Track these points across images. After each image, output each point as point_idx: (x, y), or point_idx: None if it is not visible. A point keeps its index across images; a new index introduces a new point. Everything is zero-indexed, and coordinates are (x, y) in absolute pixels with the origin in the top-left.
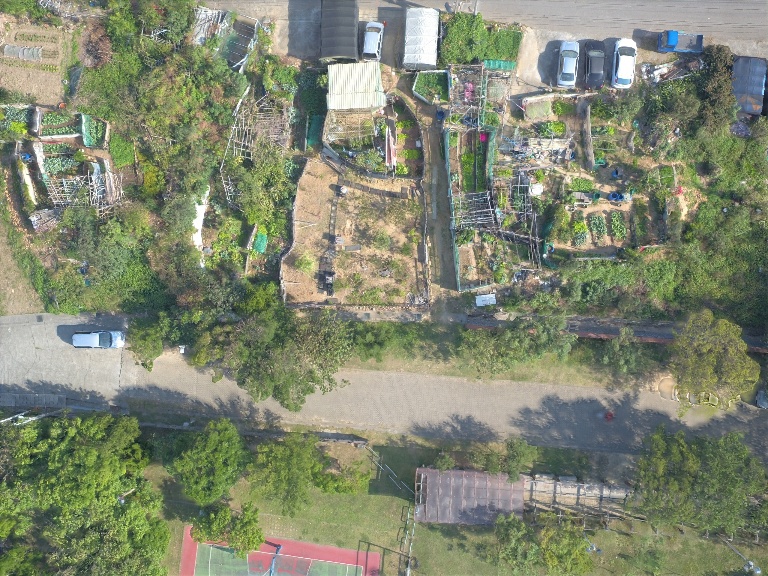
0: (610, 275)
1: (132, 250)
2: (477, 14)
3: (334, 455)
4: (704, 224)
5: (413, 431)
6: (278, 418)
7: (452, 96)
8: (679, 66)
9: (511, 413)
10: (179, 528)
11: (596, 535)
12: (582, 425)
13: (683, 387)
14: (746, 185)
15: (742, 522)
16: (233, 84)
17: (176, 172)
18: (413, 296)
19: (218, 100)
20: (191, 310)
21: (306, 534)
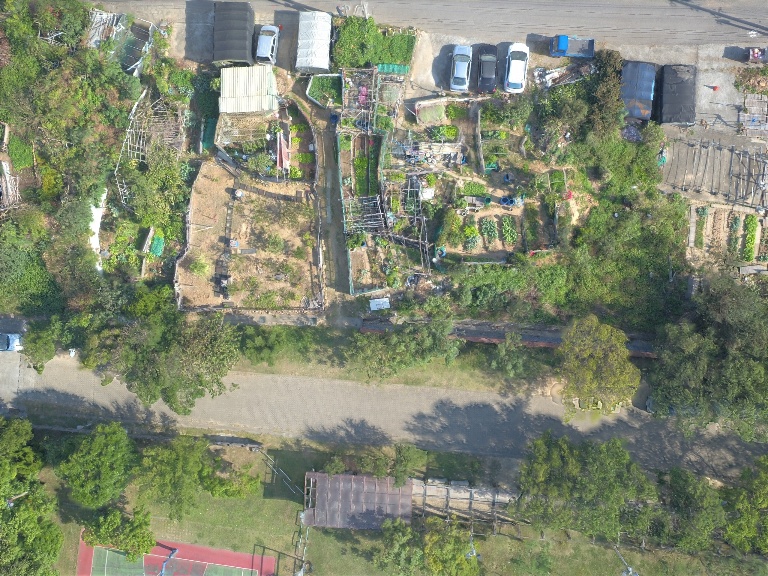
0: (502, 279)
1: (28, 253)
2: (368, 18)
3: (229, 459)
4: (595, 229)
5: (307, 435)
6: (174, 421)
7: (343, 100)
8: (571, 71)
9: (404, 417)
10: (76, 531)
11: (488, 540)
12: (475, 430)
13: (569, 392)
14: (637, 190)
15: None
16: (126, 87)
17: (73, 175)
18: (308, 300)
19: (114, 103)
20: (81, 313)
21: (202, 538)
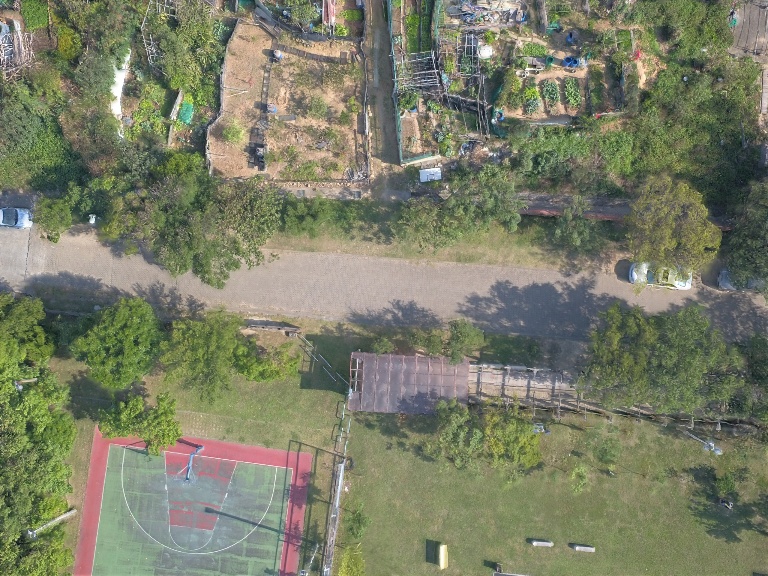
0: (563, 147)
1: (42, 117)
2: None
3: (263, 345)
4: (663, 93)
5: (350, 318)
6: (202, 304)
7: None
8: None
9: (457, 298)
10: (89, 427)
11: None
12: (533, 311)
13: (640, 261)
14: (707, 53)
15: (703, 405)
16: None
17: (93, 33)
18: (352, 171)
19: None
20: (103, 175)
21: (231, 433)
